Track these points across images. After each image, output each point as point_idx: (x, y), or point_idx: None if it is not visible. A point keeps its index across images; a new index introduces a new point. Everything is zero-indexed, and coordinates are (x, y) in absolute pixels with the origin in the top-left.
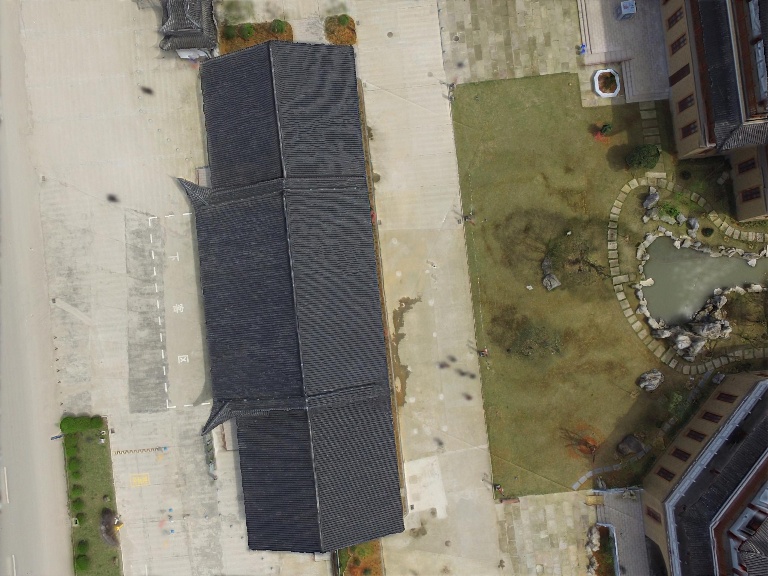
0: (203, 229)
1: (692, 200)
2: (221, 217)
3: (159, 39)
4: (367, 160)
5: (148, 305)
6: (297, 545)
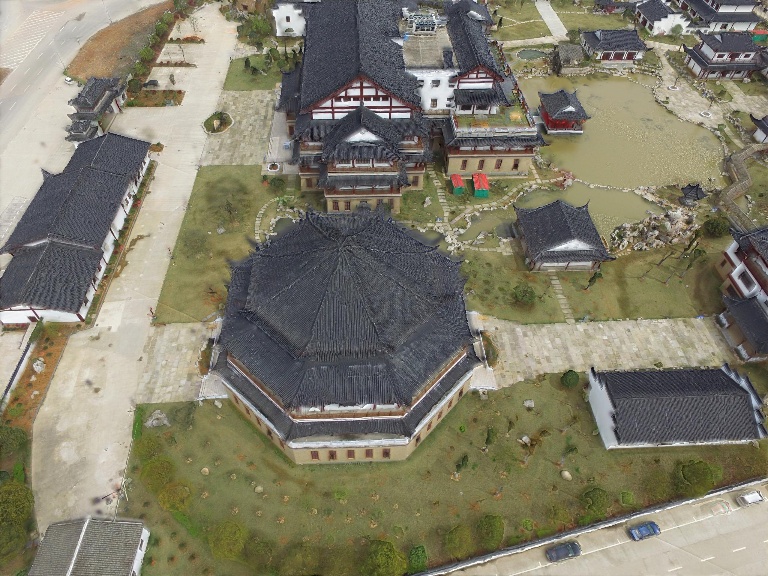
0: (43, 187)
1: (305, 205)
2: (54, 181)
3: (72, 147)
4: (147, 186)
5: (1, 230)
6: (6, 305)
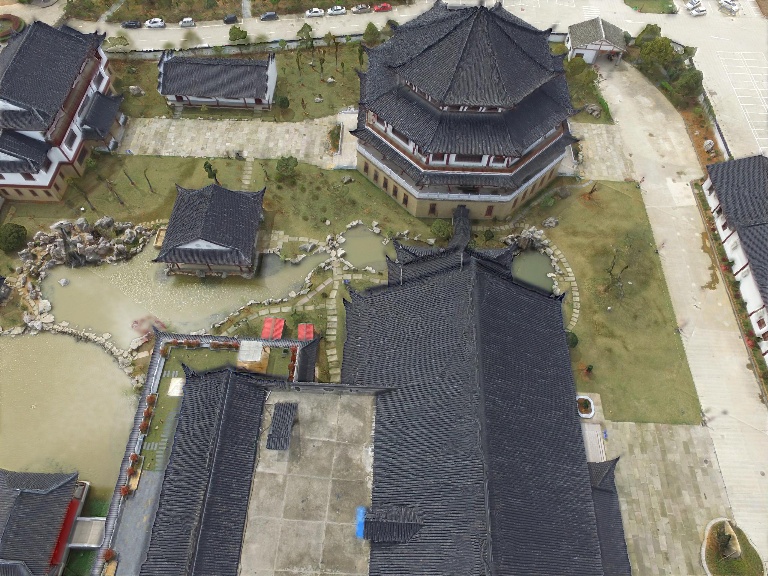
0: None
1: None
2: None
3: None
4: (760, 379)
5: None
6: None
